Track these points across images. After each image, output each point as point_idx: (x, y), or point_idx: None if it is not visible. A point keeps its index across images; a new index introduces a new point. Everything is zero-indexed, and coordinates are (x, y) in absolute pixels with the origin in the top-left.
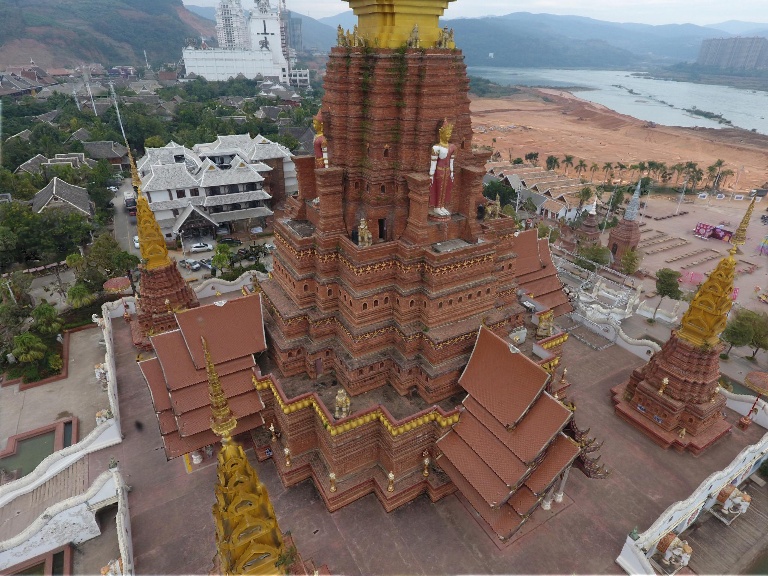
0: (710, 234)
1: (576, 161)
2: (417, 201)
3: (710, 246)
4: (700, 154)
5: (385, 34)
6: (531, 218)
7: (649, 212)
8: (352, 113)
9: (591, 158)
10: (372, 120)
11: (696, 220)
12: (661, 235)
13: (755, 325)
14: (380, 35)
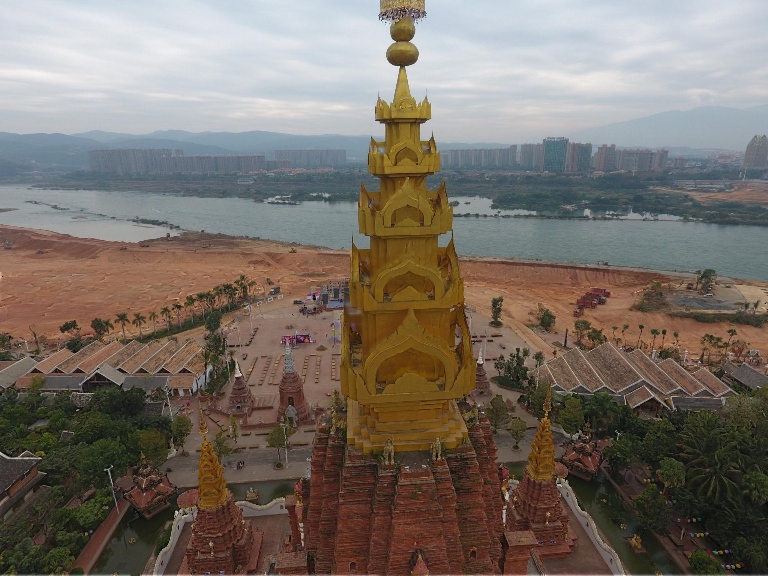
0: (296, 342)
1: (130, 316)
2: (523, 560)
3: (305, 352)
4: (195, 265)
5: (455, 426)
6: (179, 409)
7: (234, 340)
8: (458, 531)
9: (108, 298)
10: (476, 521)
11: (270, 332)
12: (269, 359)
13: None
14: (450, 430)
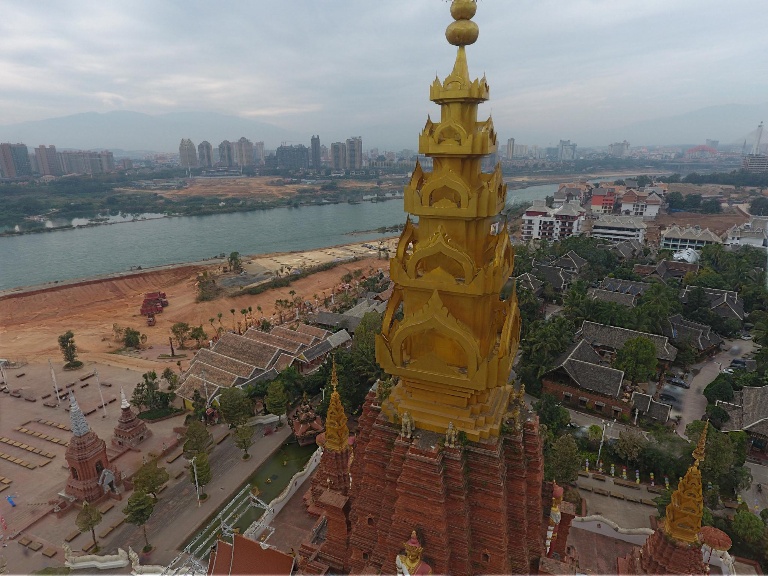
0: None
1: None
2: None
3: None
4: None
5: None
6: None
7: None
8: None
9: None
10: None
11: None
12: None
13: (152, 477)
14: None
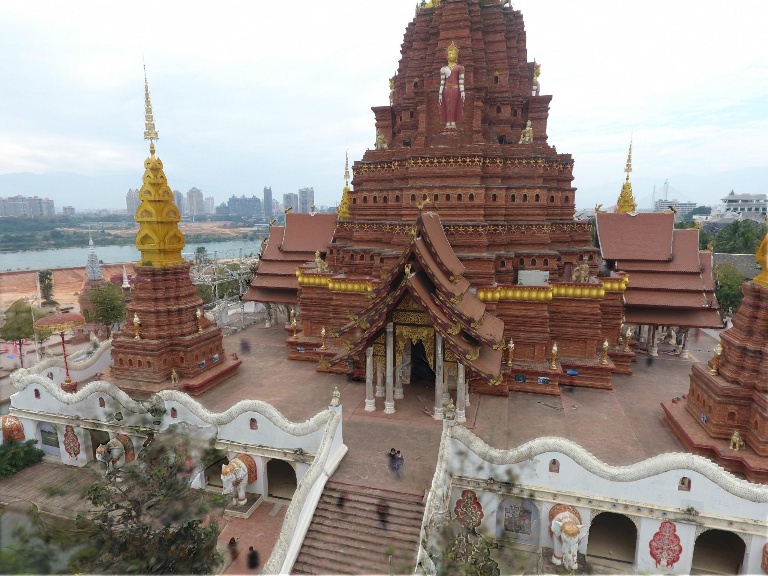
0: None
1: None
2: None
3: None
4: None
5: None
6: None
7: None
8: None
9: None
10: None
11: None
12: None
13: None
14: None
